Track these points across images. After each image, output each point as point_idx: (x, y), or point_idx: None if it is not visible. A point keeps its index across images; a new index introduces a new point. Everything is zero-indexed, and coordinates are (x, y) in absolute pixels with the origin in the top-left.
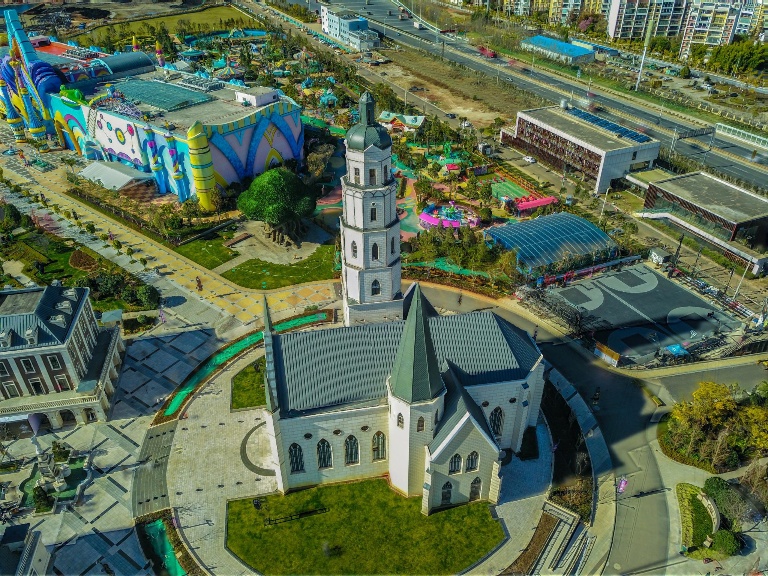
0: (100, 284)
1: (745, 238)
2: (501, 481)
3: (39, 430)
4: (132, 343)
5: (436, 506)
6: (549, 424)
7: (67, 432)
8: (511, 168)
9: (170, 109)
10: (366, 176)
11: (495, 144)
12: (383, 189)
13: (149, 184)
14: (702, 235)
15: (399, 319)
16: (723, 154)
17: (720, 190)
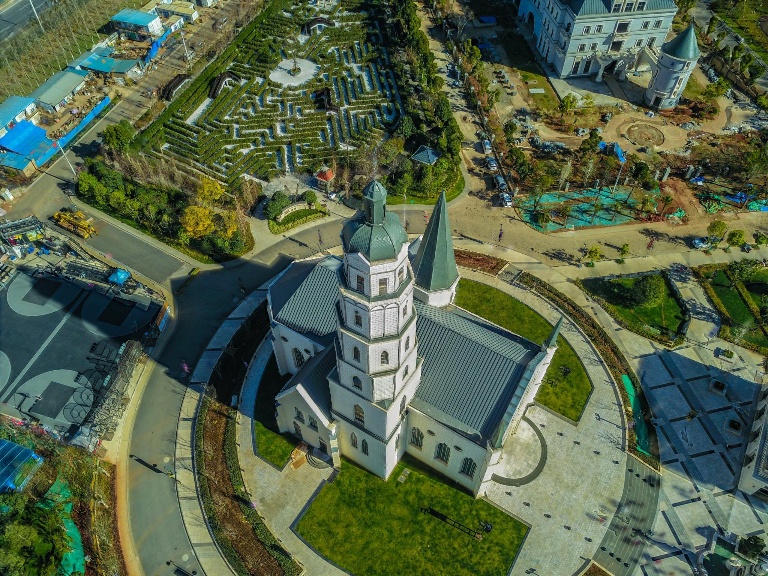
0: None
1: None
2: None
3: None
4: None
5: None
6: None
7: None
8: None
9: None
10: None
11: None
12: None
13: None
14: None
15: None
16: None
17: None
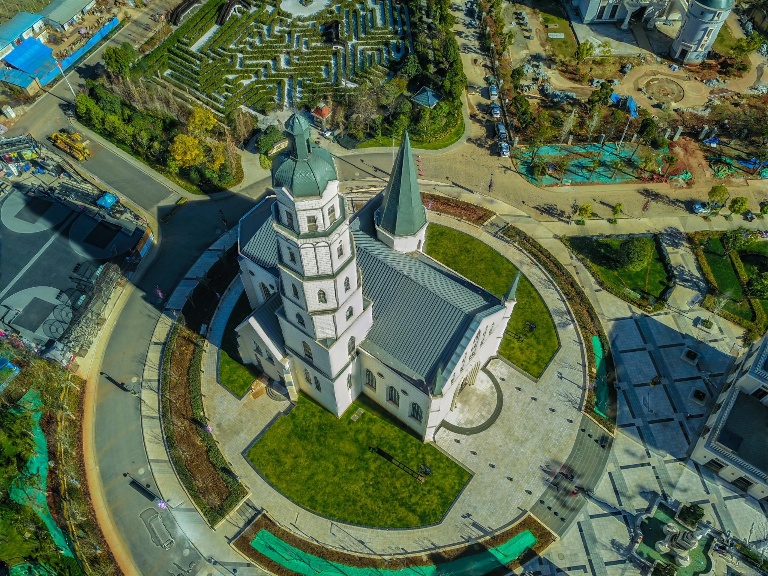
0: None
1: None
2: None
3: None
4: None
5: None
6: None
7: None
8: None
9: None
10: None
11: None
12: None
13: None
14: None
15: None
16: None
17: None
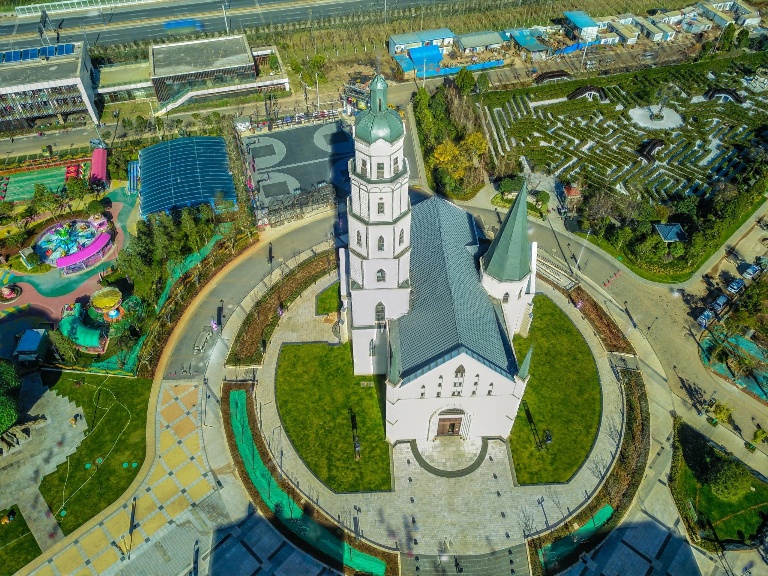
0: None
1: None
2: None
3: None
4: None
5: None
6: None
7: None
8: None
9: None
10: None
11: None
12: None
13: None
14: (234, 89)
15: None
16: (75, 31)
17: (191, 50)
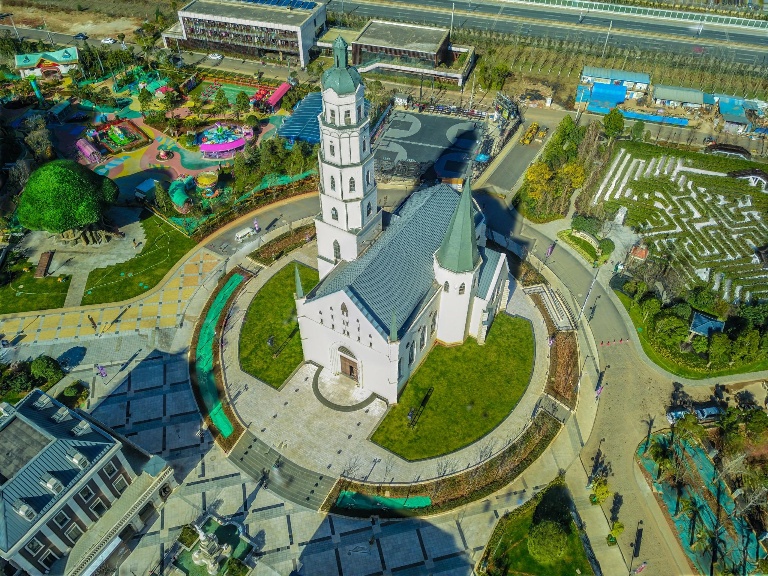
0: None
1: (438, 62)
2: None
3: (126, 545)
4: None
5: None
6: None
7: (157, 522)
8: (210, 71)
9: None
10: (356, 114)
11: None
12: None
13: None
14: (413, 71)
15: (380, 226)
16: None
17: (398, 31)
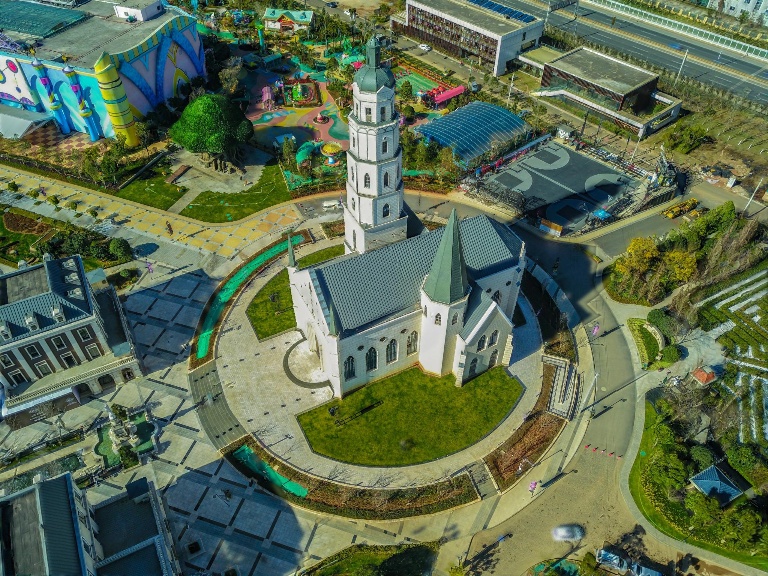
0: (62, 246)
1: (628, 106)
2: (512, 348)
3: (81, 399)
4: (126, 299)
5: (465, 378)
6: (526, 295)
7: (110, 394)
8: (411, 59)
9: (45, 35)
10: (378, 114)
11: (387, 33)
12: (393, 124)
13: (46, 124)
14: (595, 108)
15: (404, 233)
16: (587, 22)
17: (602, 63)
